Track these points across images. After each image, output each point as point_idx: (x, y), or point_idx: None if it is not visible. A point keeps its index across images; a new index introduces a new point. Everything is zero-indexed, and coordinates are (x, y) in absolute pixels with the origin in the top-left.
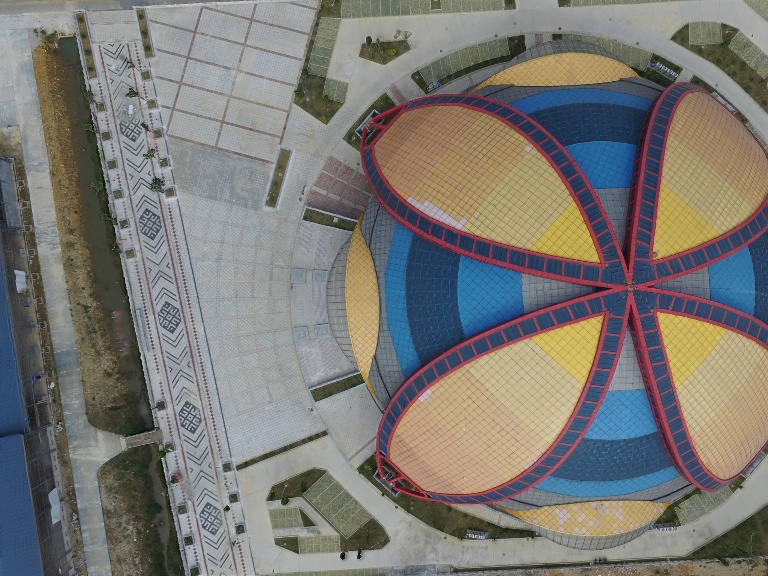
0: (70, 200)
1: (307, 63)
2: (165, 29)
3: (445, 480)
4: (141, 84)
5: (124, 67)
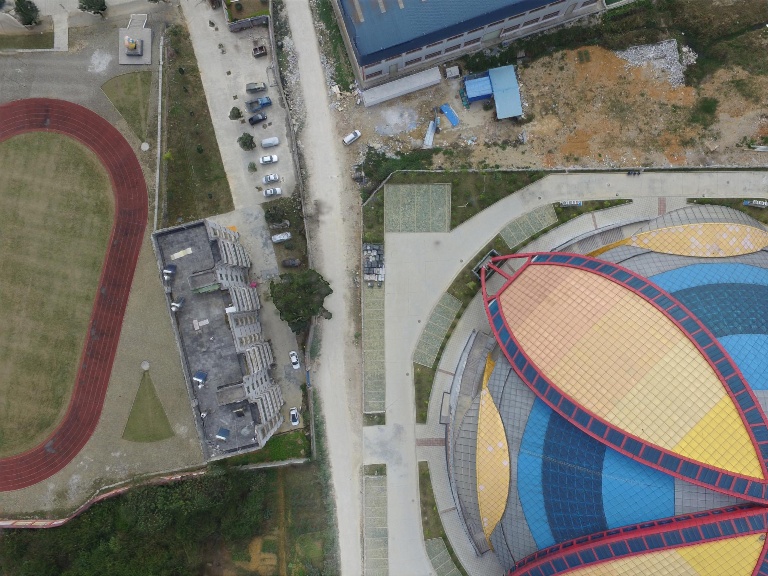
0: None
1: None
2: None
3: None
4: None
5: None
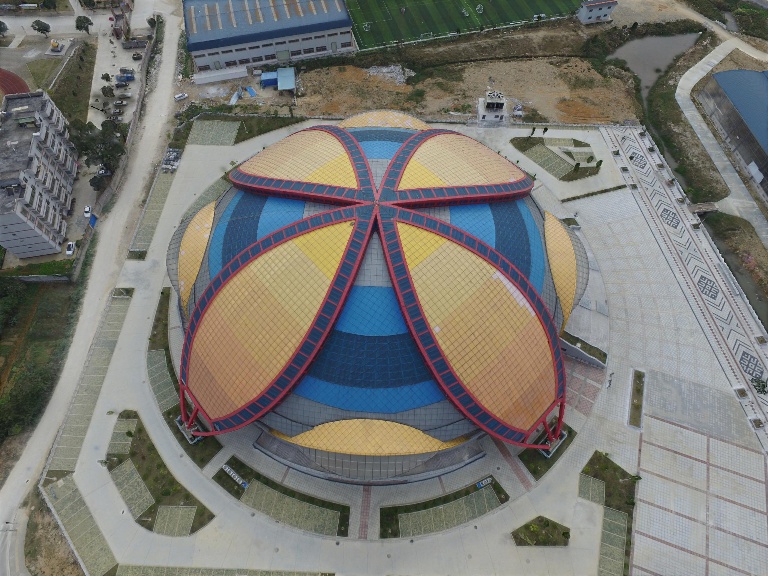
0: None
1: (629, 526)
2: None
3: None
4: None
5: None
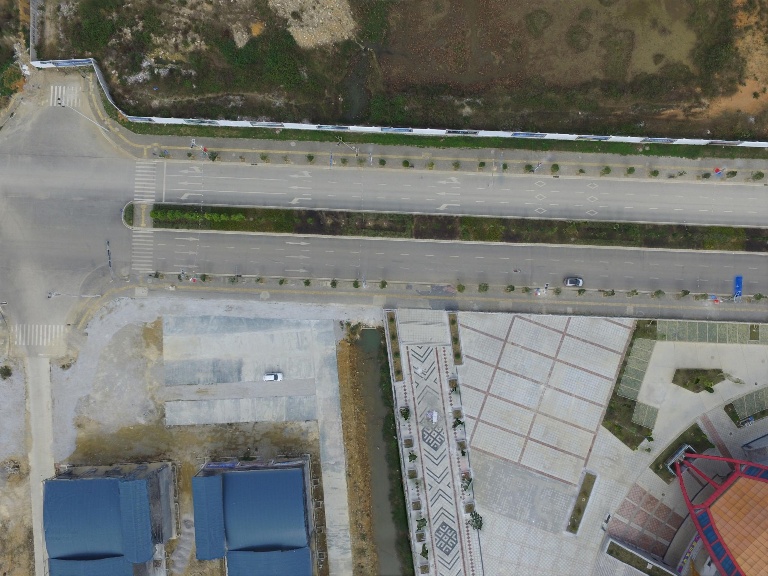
0: (364, 503)
1: (618, 384)
2: (475, 335)
3: None
4: (447, 391)
5: (430, 371)
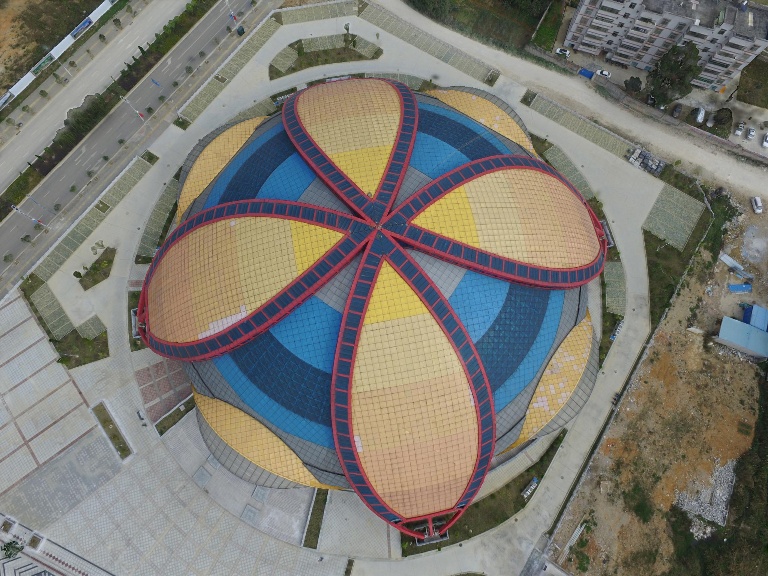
0: None
1: (51, 335)
2: None
3: (449, 482)
4: None
5: None
